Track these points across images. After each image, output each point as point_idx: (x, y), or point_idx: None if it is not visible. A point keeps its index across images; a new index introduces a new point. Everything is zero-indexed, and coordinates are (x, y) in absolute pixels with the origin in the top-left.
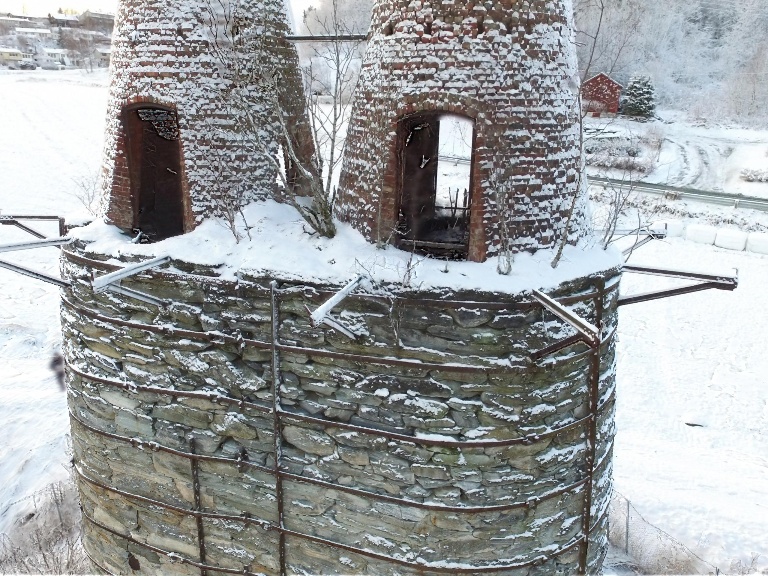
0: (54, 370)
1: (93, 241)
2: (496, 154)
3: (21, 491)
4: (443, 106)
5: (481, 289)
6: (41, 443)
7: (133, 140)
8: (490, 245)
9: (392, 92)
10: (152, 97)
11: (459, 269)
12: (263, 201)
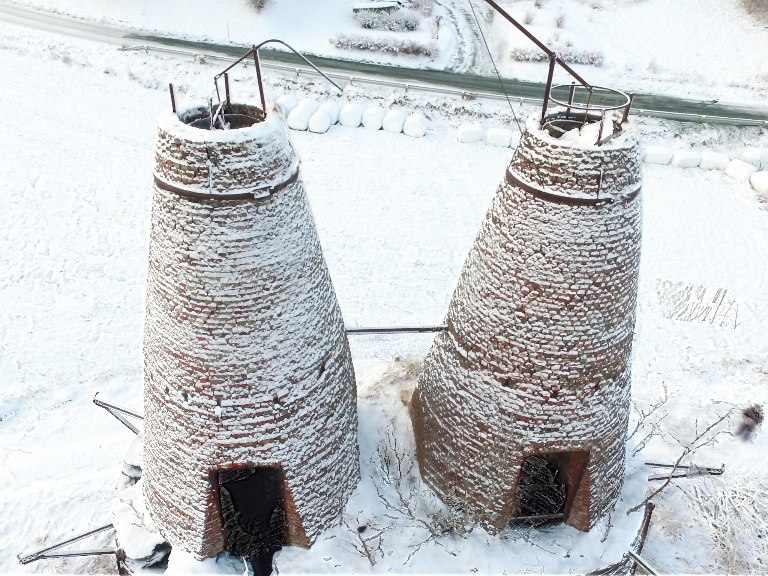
0: None
1: None
2: (600, 466)
3: None
4: (567, 449)
5: (600, 569)
6: None
7: (215, 484)
8: (592, 522)
9: (517, 438)
10: (252, 463)
11: (578, 552)
12: (355, 489)
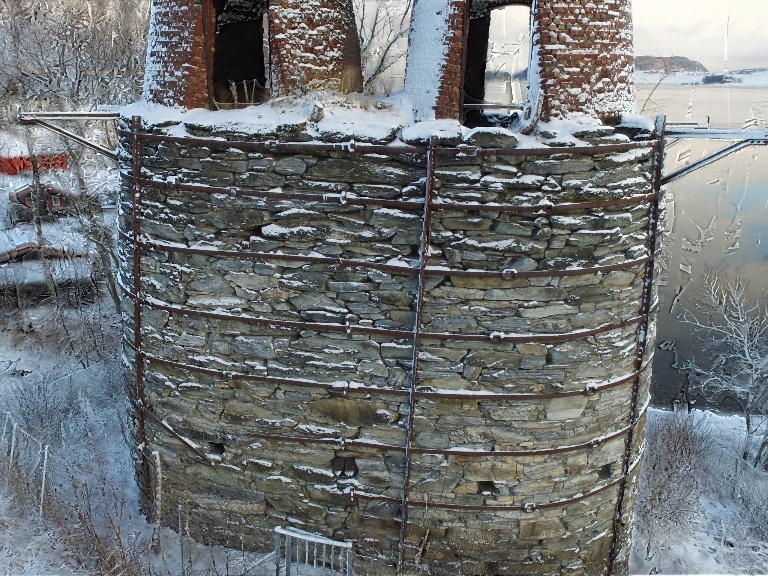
0: None
1: None
2: None
3: None
4: None
5: None
6: None
7: None
8: None
9: None
10: None
11: None
12: None
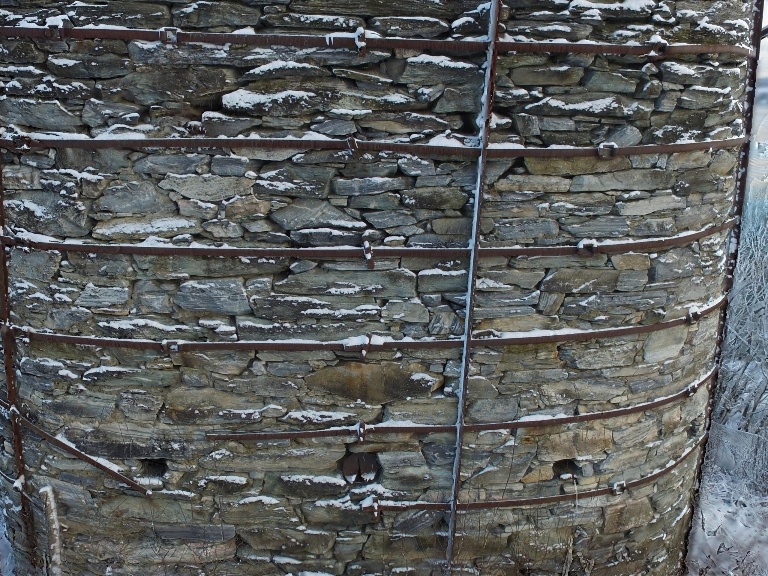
0: None
1: None
2: None
3: None
4: None
5: None
6: None
7: None
8: None
9: None
10: None
11: None
12: None
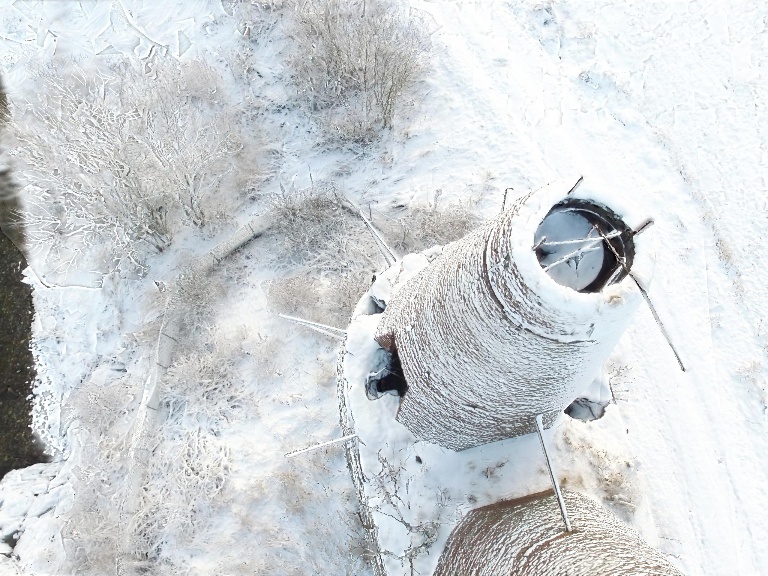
0: (512, 49)
1: (352, 354)
2: None
3: (413, 173)
4: None
5: None
6: (445, 143)
7: None
8: None
9: None
10: None
11: None
12: (447, 448)
